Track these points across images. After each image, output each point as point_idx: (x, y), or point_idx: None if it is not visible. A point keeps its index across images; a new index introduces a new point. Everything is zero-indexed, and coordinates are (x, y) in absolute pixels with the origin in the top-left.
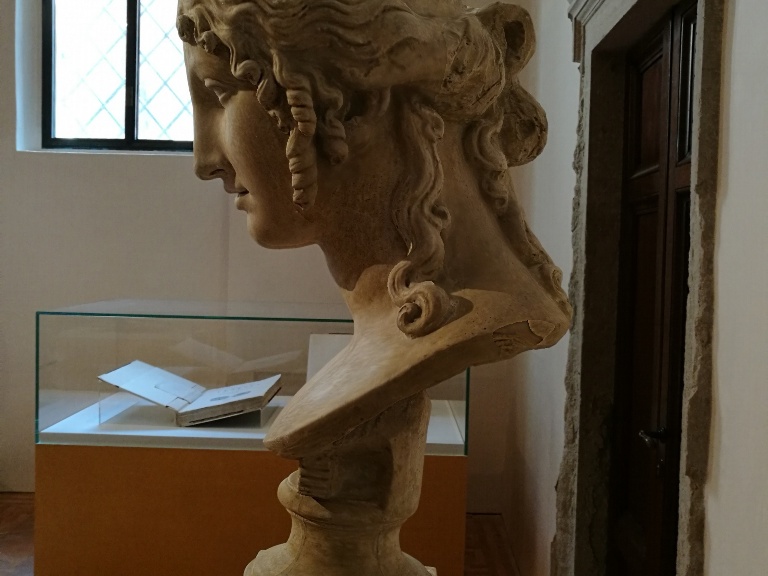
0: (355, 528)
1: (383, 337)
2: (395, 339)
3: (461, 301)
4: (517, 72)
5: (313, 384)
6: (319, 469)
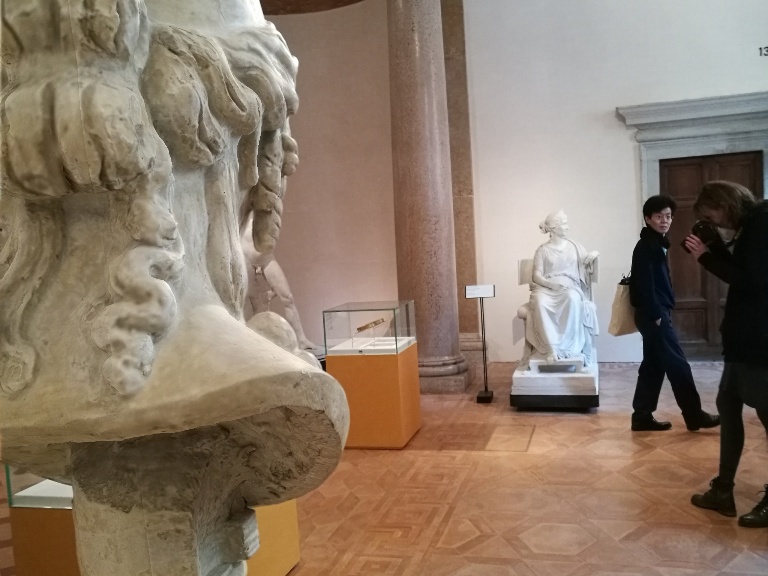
0: None
1: None
2: None
3: None
4: (6, 69)
5: None
6: None
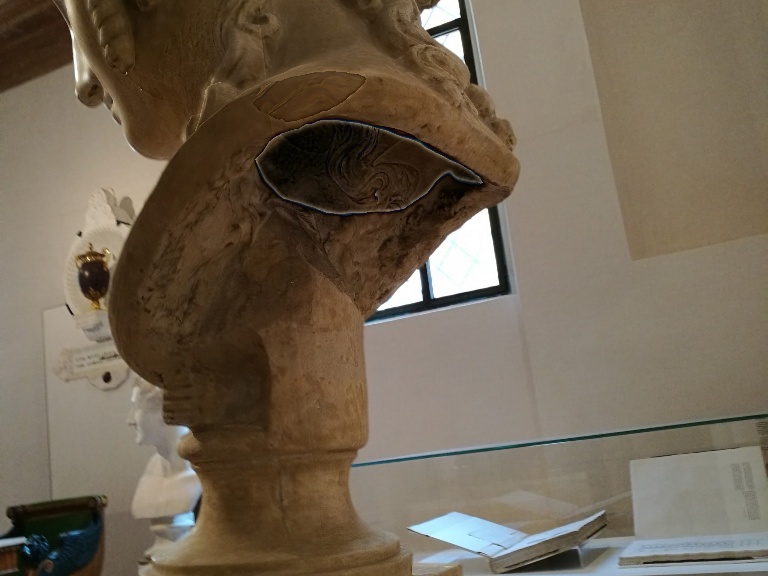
0: (237, 463)
1: None
2: None
3: (254, 93)
4: None
5: None
6: (180, 385)
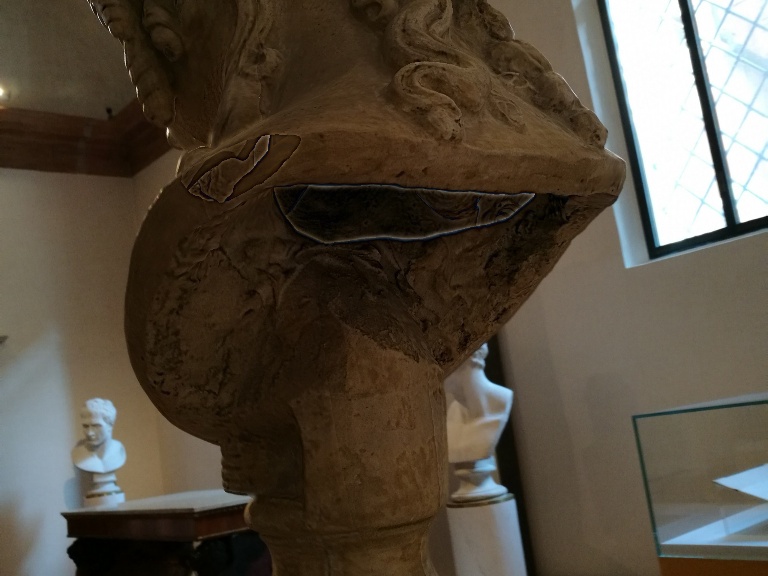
0: (284, 540)
1: None
2: None
3: (224, 157)
4: None
5: None
6: (232, 455)
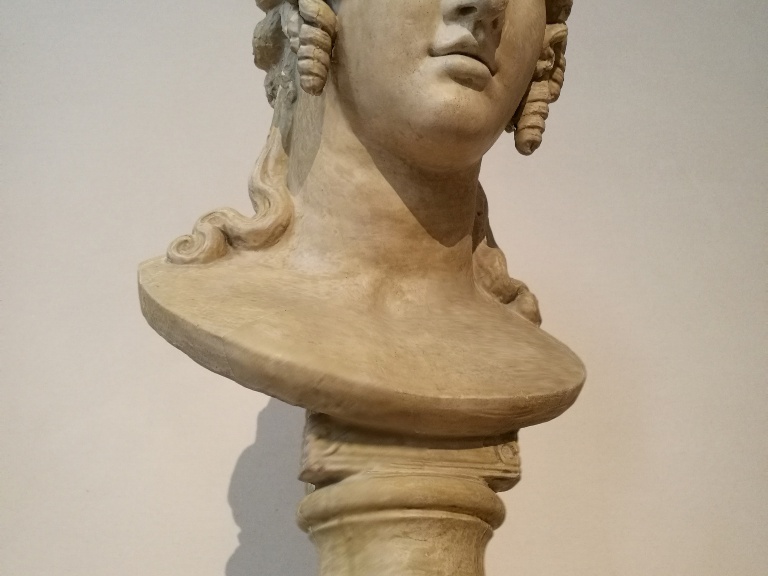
0: None
1: (498, 314)
2: (523, 321)
3: None
4: None
5: (451, 339)
6: None
